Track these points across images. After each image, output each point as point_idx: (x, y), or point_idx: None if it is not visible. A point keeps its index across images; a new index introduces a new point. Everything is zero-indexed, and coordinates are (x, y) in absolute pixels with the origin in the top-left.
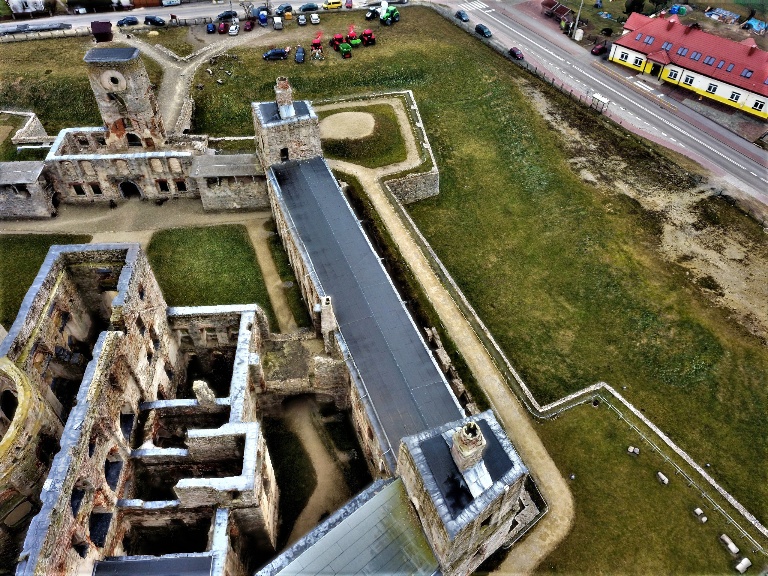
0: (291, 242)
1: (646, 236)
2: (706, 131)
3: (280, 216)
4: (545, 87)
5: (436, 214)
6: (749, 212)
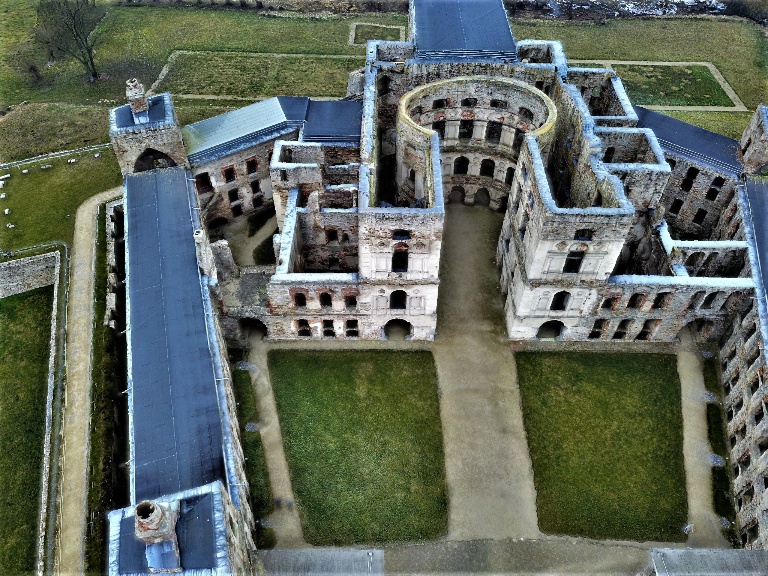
0: None
1: None
2: None
3: None
4: None
5: None
6: None
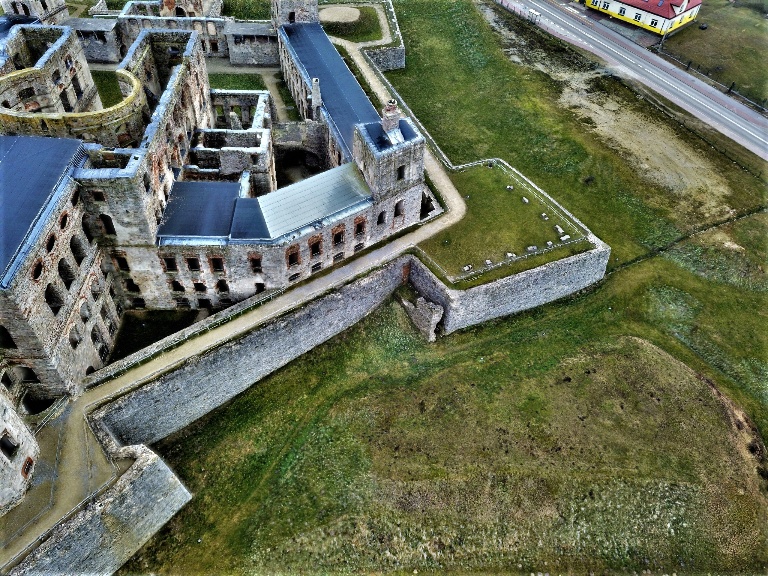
0: (294, 70)
1: (550, 94)
2: (612, 39)
3: (287, 58)
4: (495, 6)
5: (401, 79)
6: (629, 86)
